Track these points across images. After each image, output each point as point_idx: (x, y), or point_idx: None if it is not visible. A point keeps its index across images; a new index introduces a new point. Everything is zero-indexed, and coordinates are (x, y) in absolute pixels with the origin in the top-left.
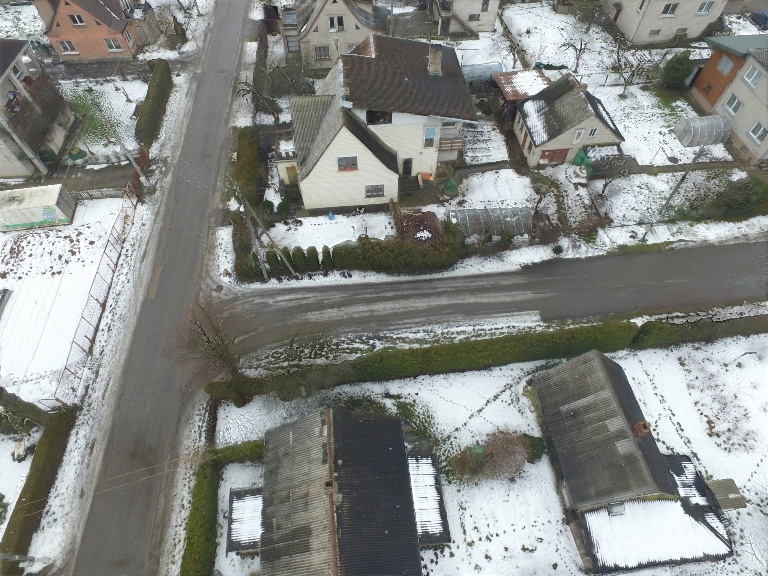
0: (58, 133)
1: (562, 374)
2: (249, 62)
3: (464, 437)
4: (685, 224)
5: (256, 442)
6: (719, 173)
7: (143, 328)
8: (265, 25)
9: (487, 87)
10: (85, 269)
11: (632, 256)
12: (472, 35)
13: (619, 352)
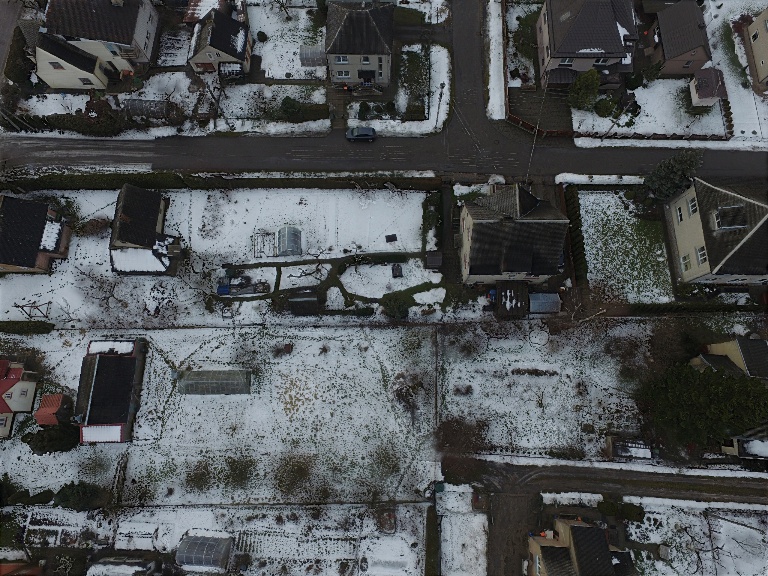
0: None
1: None
2: None
3: None
4: (265, 121)
5: None
6: (309, 88)
7: None
8: None
9: None
10: None
11: (219, 138)
12: None
13: (182, 189)
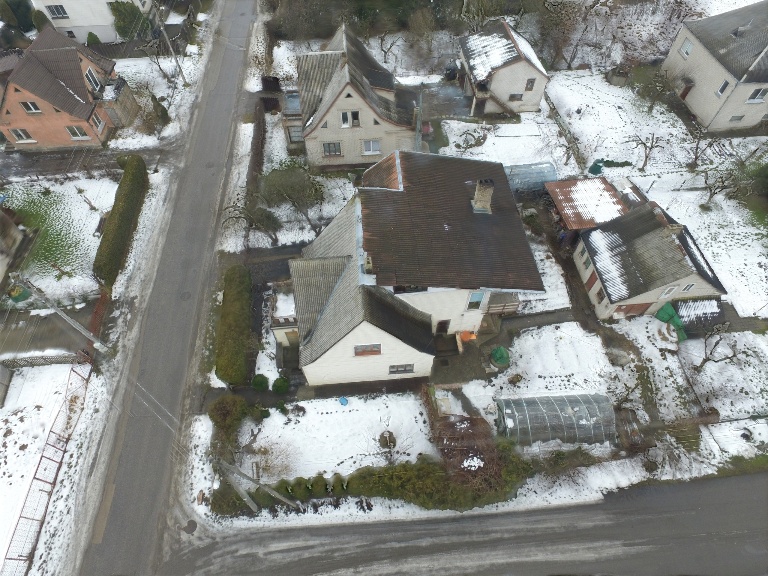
0: None
1: None
2: (243, 153)
3: None
4: None
5: None
6: None
7: None
8: (263, 104)
9: (536, 195)
10: (12, 489)
11: (753, 477)
12: (512, 117)
13: None
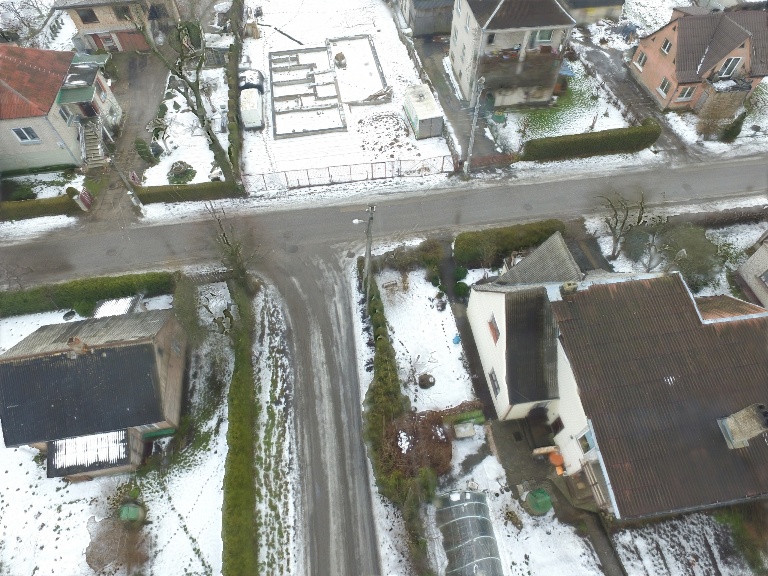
0: (516, 96)
1: None
2: (721, 208)
3: (160, 507)
4: None
5: (180, 306)
6: None
7: (311, 213)
8: None
9: None
10: None
11: None
12: None
13: None
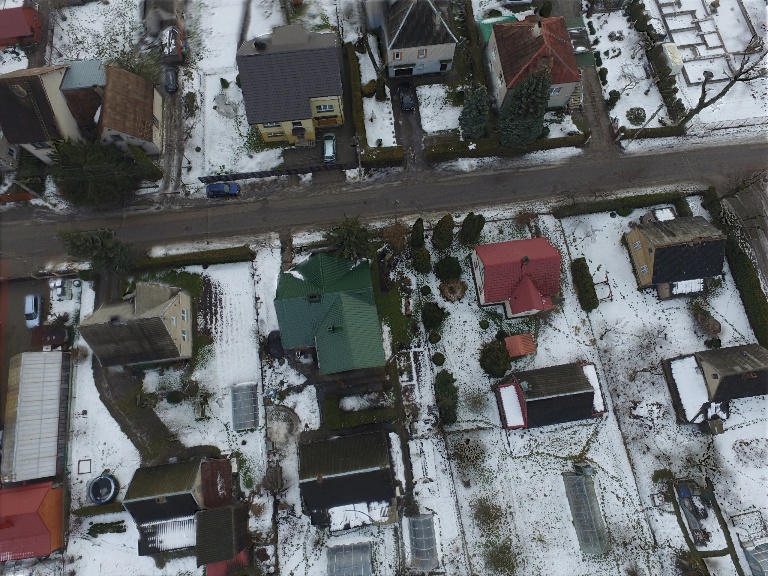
0: None
1: (766, 353)
2: None
3: (710, 312)
4: None
5: (692, 214)
6: None
7: (732, 149)
8: None
9: None
10: (760, 109)
11: None
12: None
13: None
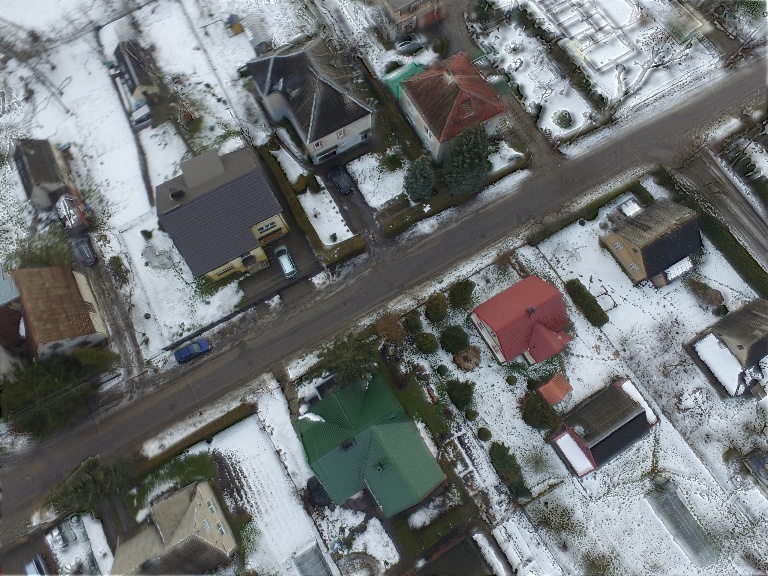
0: None
1: None
2: None
3: (704, 281)
4: None
5: (652, 196)
6: None
7: (657, 119)
8: None
9: None
10: (665, 72)
11: None
12: None
13: None
